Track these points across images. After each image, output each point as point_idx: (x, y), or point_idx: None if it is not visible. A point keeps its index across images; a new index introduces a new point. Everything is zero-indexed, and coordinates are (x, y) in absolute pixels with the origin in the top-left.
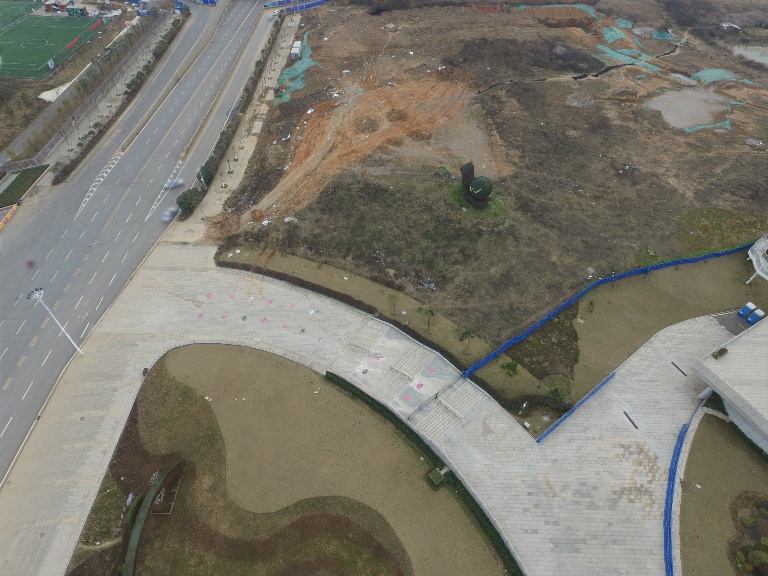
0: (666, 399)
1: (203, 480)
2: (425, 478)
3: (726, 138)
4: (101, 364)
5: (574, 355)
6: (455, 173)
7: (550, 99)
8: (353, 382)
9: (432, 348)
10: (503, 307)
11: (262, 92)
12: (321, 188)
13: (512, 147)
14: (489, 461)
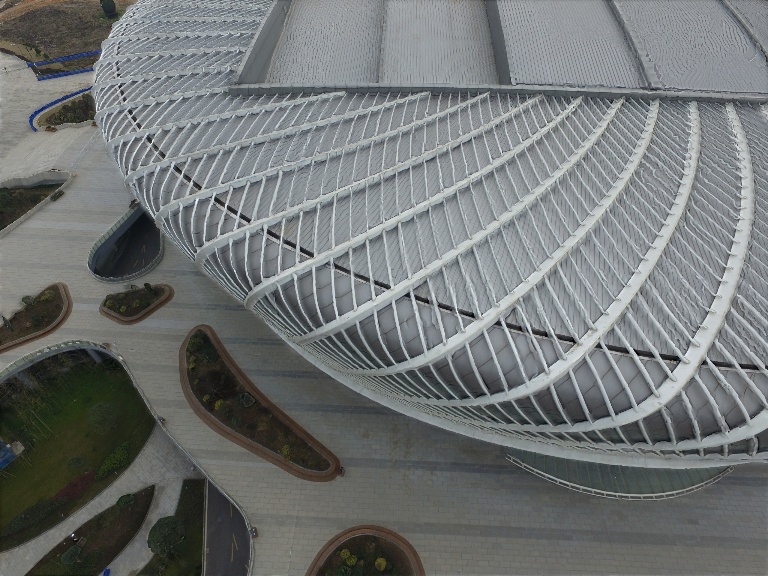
0: None
1: None
2: None
3: None
4: None
5: None
6: (117, 7)
7: None
8: None
9: (25, 60)
10: None
11: None
12: None
13: None
14: (8, 84)
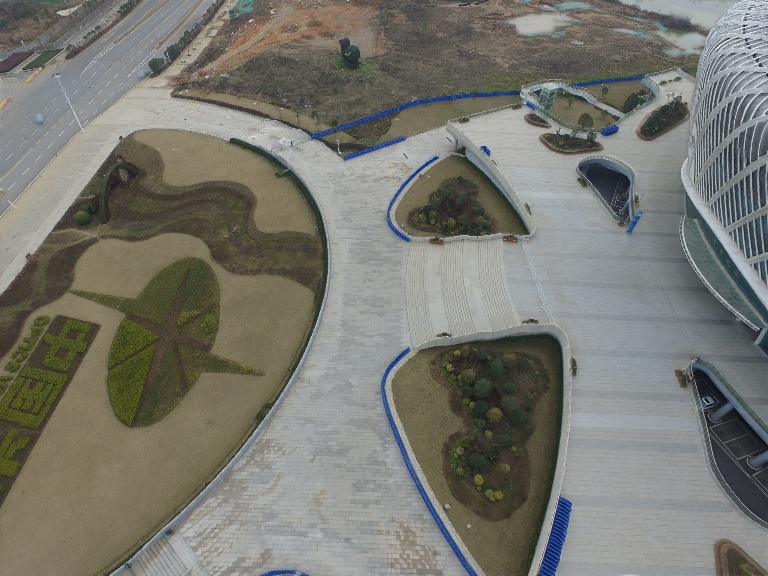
0: (433, 150)
1: (150, 177)
2: (275, 174)
3: (556, 40)
4: (95, 136)
5: (384, 131)
6: None
7: (434, 17)
8: (244, 140)
9: (298, 128)
10: (351, 114)
11: (220, 13)
12: (248, 59)
13: (390, 40)
14: (312, 166)
